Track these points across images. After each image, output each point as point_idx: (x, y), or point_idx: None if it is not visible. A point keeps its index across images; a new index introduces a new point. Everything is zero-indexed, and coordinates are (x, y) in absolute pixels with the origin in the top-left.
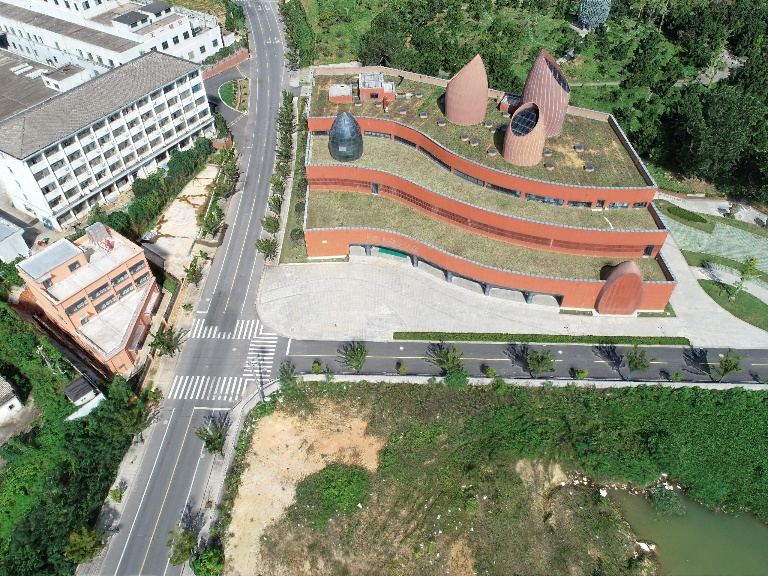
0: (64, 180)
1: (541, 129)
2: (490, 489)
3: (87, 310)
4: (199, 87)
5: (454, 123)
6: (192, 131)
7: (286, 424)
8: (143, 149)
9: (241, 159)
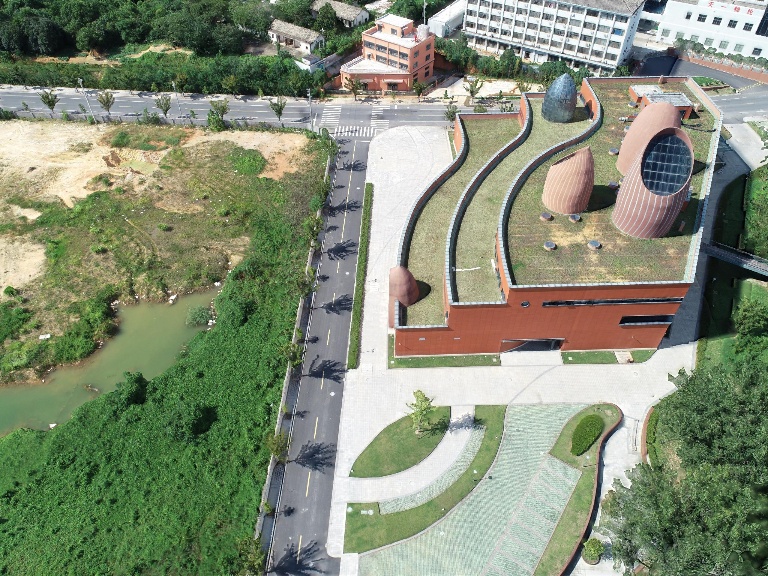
0: (484, 16)
1: (563, 172)
2: (232, 222)
3: (373, 53)
4: (622, 33)
5: None
6: (588, 60)
7: (299, 144)
8: (545, 41)
9: None
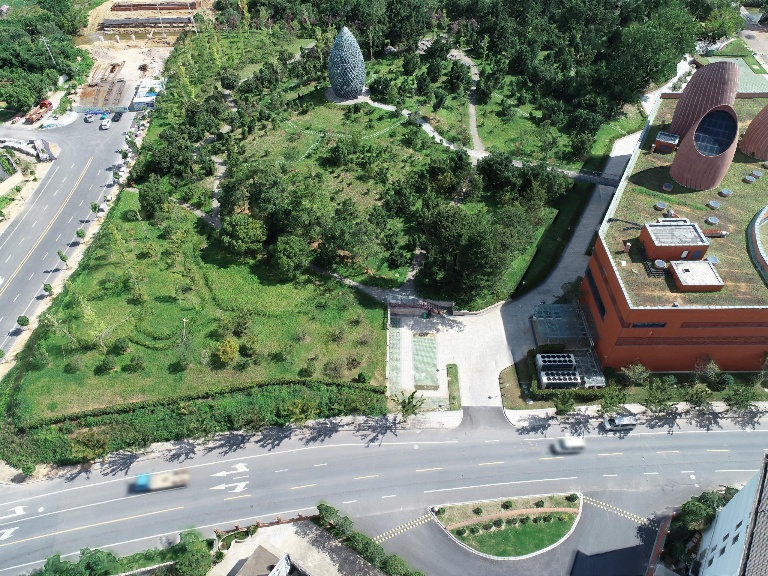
0: None
1: None
2: None
3: None
4: None
5: (720, 184)
6: None
7: None
8: None
9: (734, 485)
